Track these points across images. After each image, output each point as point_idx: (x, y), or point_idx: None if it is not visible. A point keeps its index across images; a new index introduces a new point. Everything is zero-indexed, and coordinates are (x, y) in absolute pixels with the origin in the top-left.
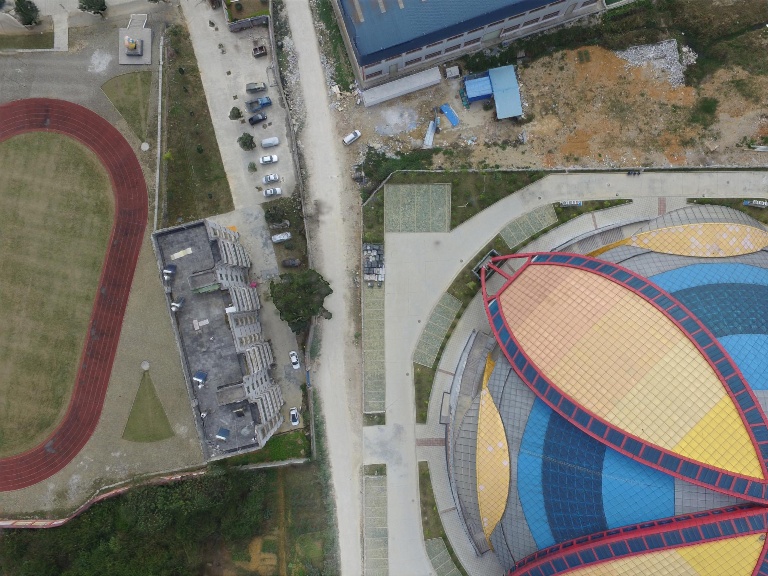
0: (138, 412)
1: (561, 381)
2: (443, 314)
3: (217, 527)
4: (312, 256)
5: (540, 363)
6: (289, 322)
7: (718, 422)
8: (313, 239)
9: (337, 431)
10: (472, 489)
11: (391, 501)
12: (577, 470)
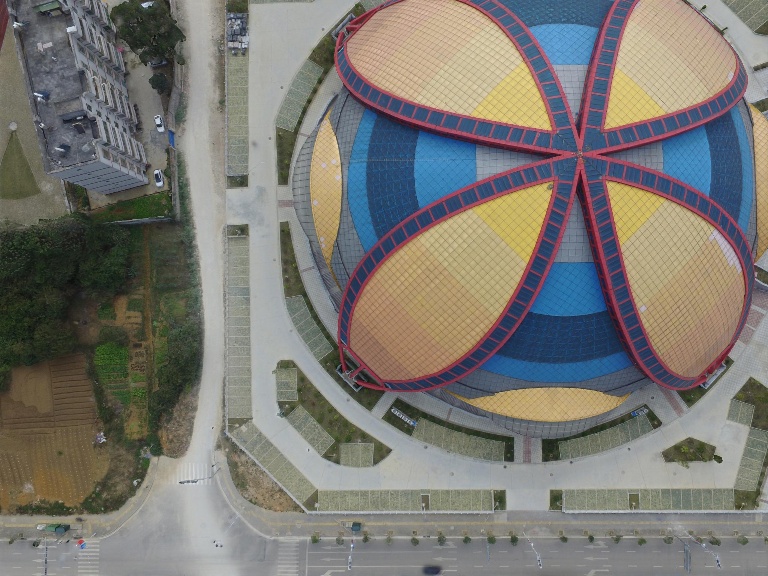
0: (5, 170)
1: (382, 82)
2: (305, 80)
3: (75, 271)
4: (178, 26)
5: (367, 74)
6: (149, 79)
7: (513, 85)
8: (180, 10)
9: (201, 193)
10: (307, 207)
11: (253, 261)
12: (394, 162)
